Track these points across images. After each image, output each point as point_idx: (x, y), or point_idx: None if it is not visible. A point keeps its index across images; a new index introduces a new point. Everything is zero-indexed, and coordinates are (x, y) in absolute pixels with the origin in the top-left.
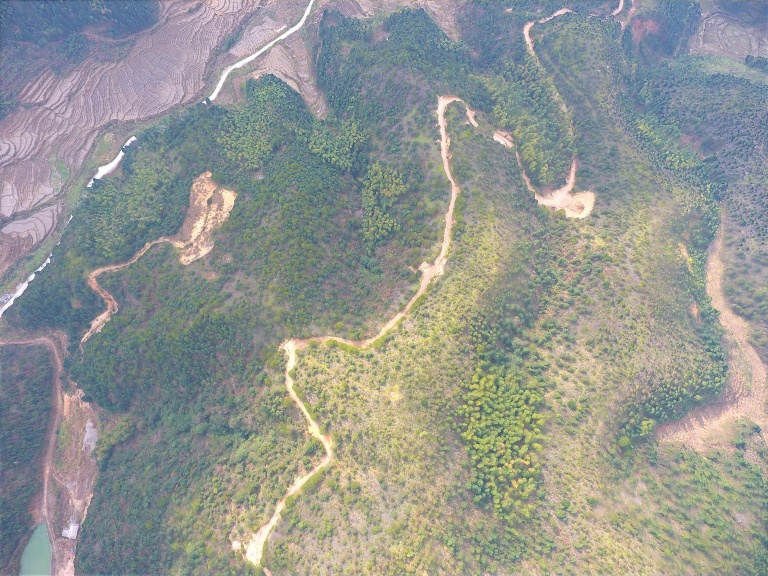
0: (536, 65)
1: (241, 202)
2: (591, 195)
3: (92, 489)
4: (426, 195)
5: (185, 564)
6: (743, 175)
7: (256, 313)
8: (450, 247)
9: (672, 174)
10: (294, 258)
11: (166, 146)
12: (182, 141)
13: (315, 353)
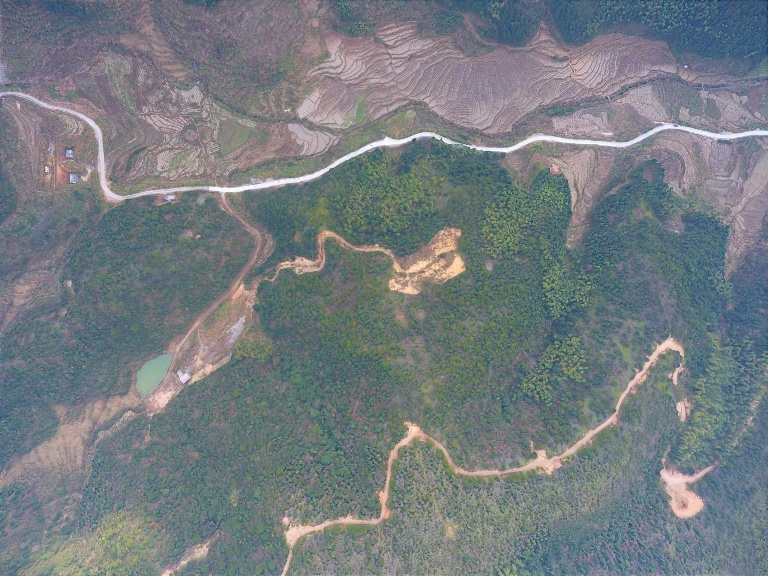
0: (766, 367)
1: (463, 280)
2: (700, 505)
3: (214, 362)
4: (589, 399)
5: (245, 489)
6: None
7: (412, 388)
8: (571, 458)
9: None
10: (466, 372)
11: (447, 177)
12: (461, 183)
13: (426, 453)
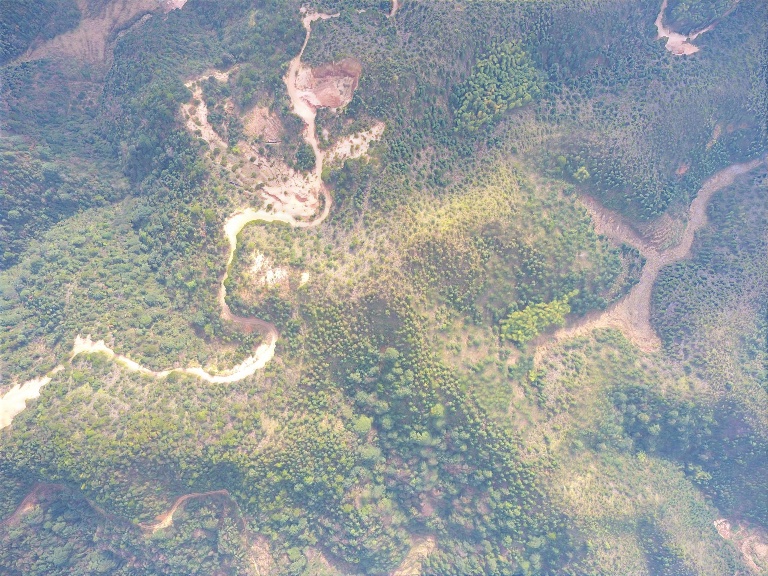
0: None
1: None
2: (696, 50)
3: None
4: None
5: (262, 13)
6: None
7: None
8: None
9: (766, 88)
10: None
11: None
12: None
13: None
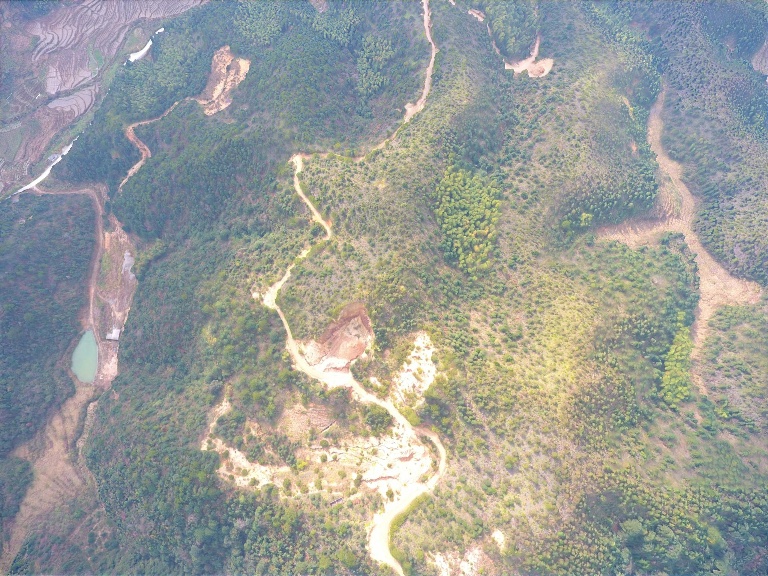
0: None
1: None
2: (550, 61)
3: (130, 303)
4: (411, 58)
5: (213, 324)
6: (682, 49)
7: (270, 135)
8: (430, 92)
9: (620, 45)
10: (300, 96)
11: (190, 28)
12: (204, 25)
13: (318, 161)
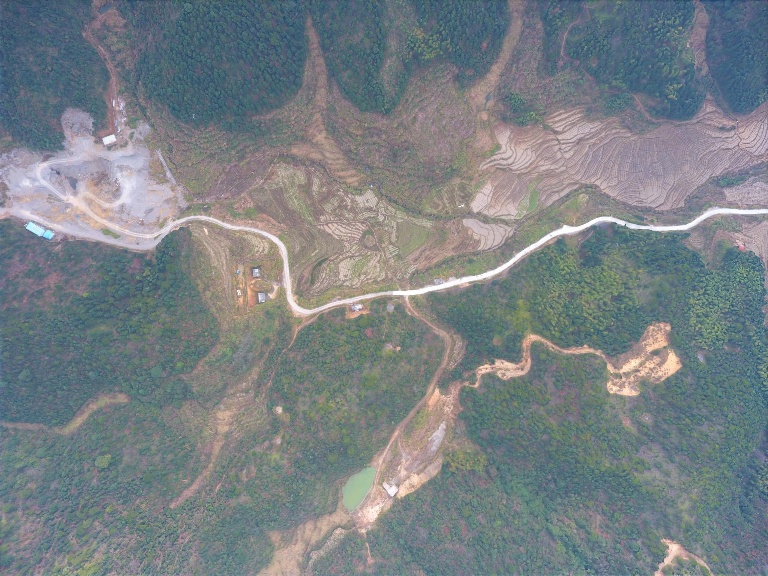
0: None
1: (684, 378)
2: None
3: (419, 471)
4: None
5: None
6: None
7: (667, 505)
8: None
9: None
10: None
11: (645, 269)
12: (659, 273)
13: (693, 573)
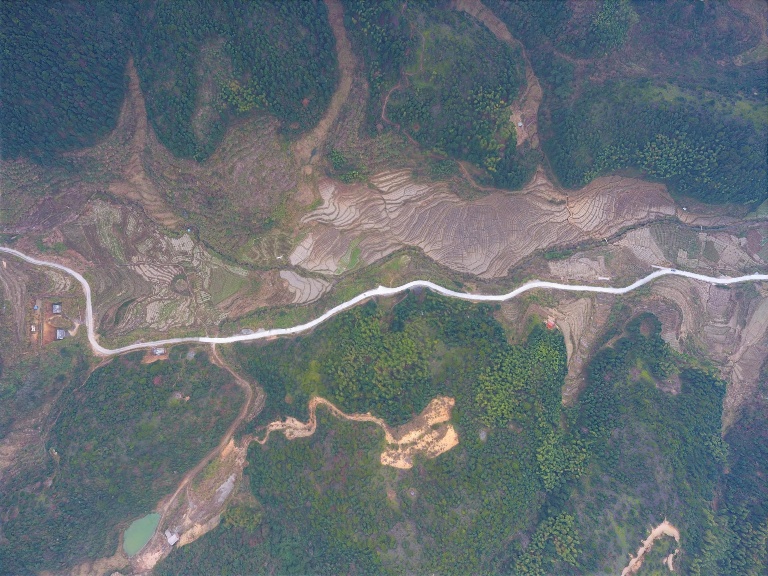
0: (762, 542)
1: (456, 455)
2: None
3: (203, 521)
4: None
5: None
6: None
7: None
8: None
9: None
10: (458, 568)
11: (441, 340)
12: (455, 345)
13: None
